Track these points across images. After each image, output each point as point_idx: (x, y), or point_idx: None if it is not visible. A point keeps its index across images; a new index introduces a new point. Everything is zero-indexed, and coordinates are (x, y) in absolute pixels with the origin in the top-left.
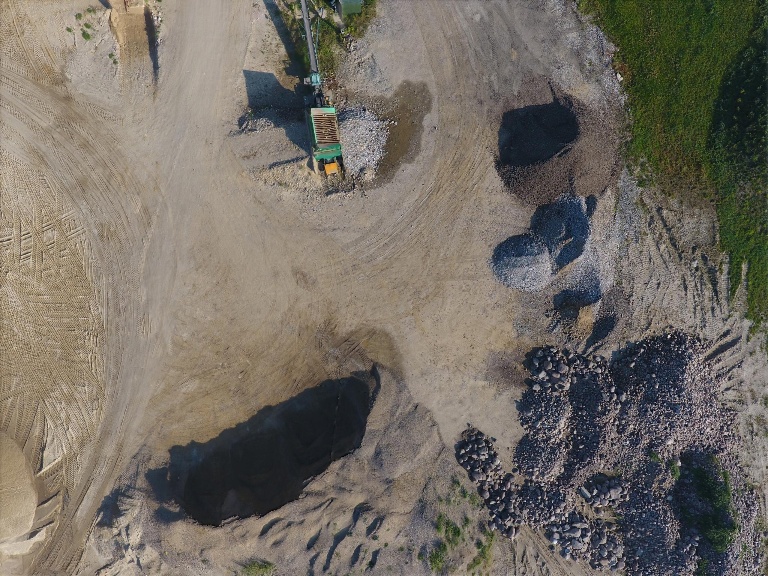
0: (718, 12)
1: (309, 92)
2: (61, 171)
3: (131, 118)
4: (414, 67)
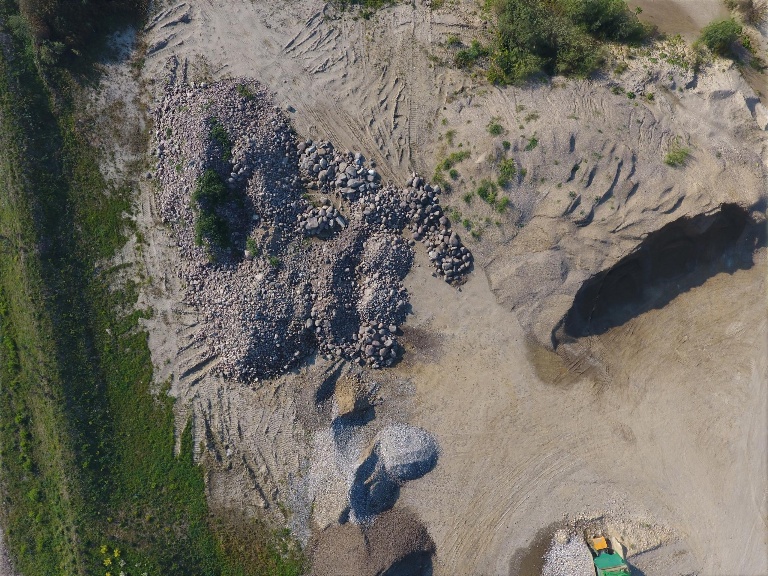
0: None
1: None
2: None
3: None
4: None
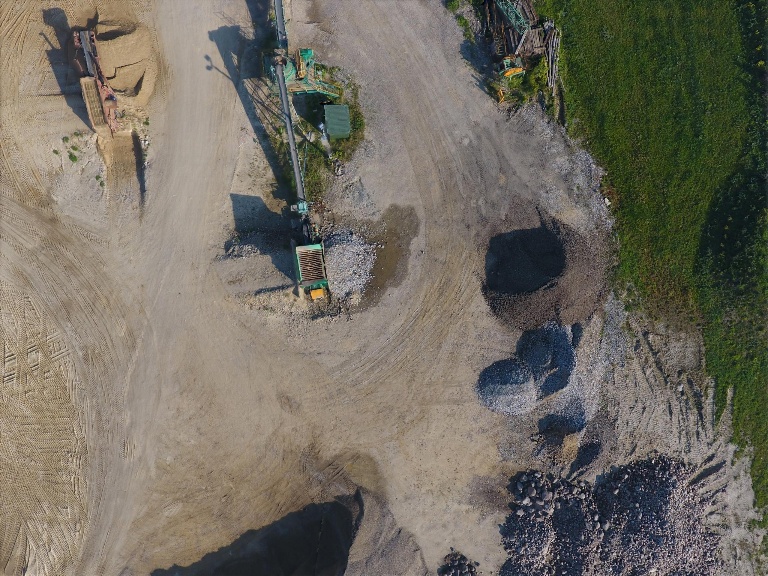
0: (707, 138)
1: (296, 216)
2: (46, 293)
3: (117, 241)
4: (402, 191)
